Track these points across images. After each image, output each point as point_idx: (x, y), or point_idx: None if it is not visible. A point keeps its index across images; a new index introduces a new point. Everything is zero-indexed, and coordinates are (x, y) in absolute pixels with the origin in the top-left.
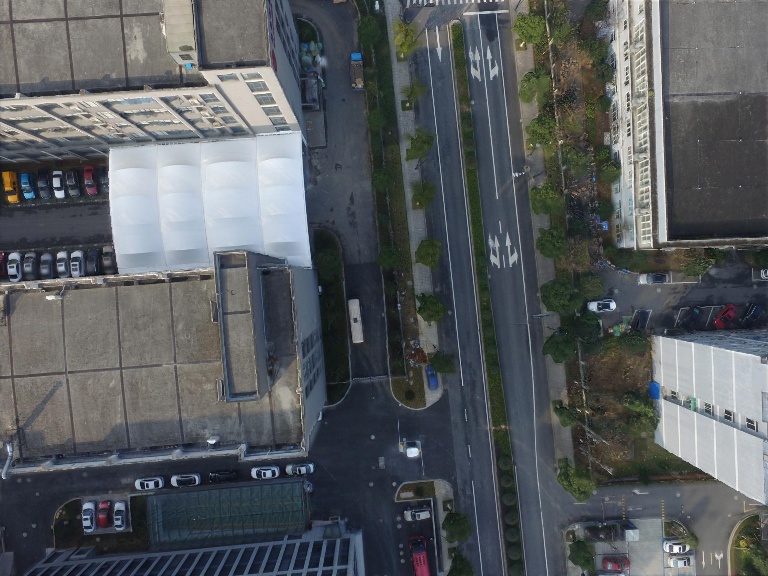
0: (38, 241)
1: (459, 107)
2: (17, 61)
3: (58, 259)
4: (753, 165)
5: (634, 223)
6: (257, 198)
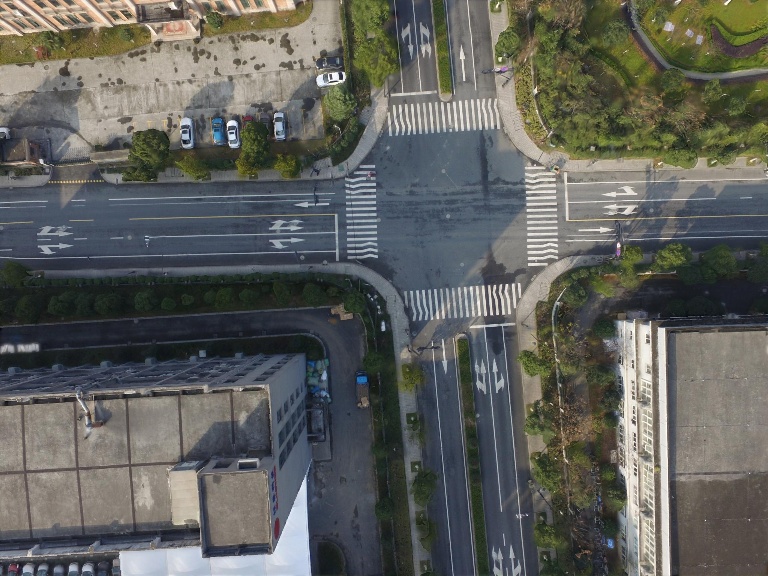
0: None
1: (464, 421)
2: (30, 508)
3: (70, 572)
4: (762, 542)
5: (639, 575)
6: None
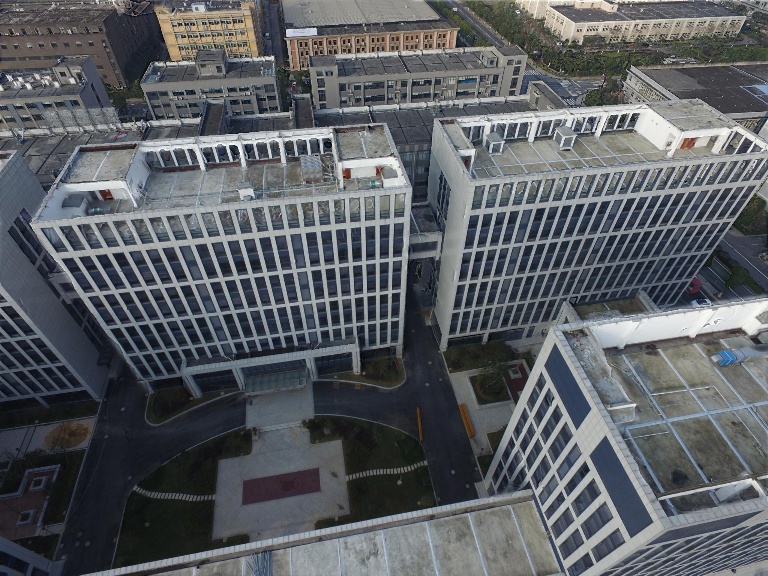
0: None
1: None
2: None
3: None
4: None
5: None
6: None
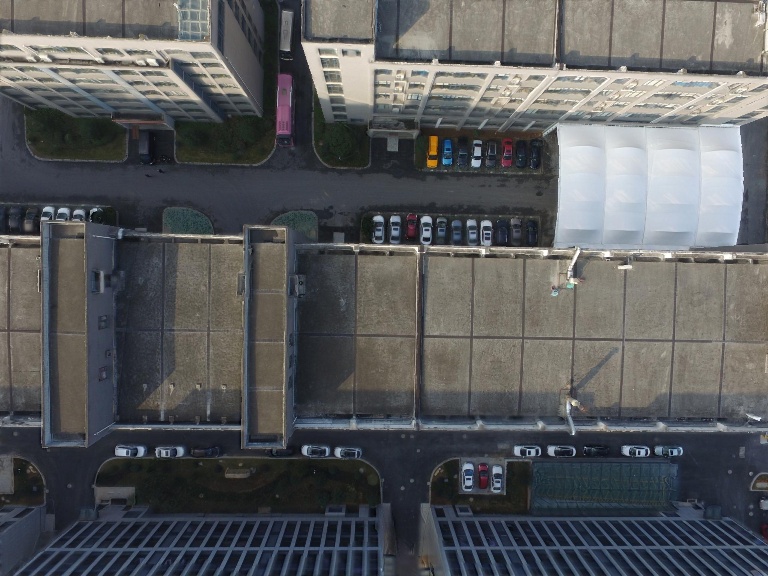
0: (446, 207)
1: None
2: (612, 34)
3: (469, 226)
4: None
5: None
6: (699, 187)
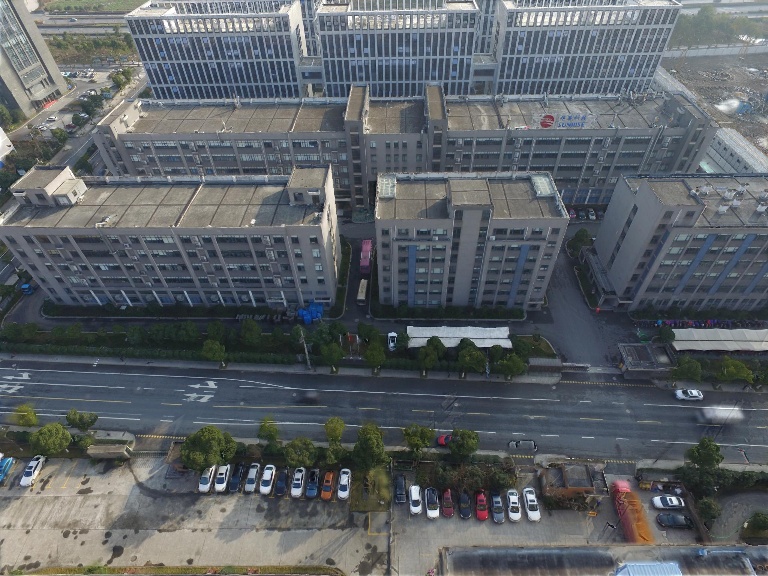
0: None
1: None
2: None
3: None
4: None
5: None
6: None
